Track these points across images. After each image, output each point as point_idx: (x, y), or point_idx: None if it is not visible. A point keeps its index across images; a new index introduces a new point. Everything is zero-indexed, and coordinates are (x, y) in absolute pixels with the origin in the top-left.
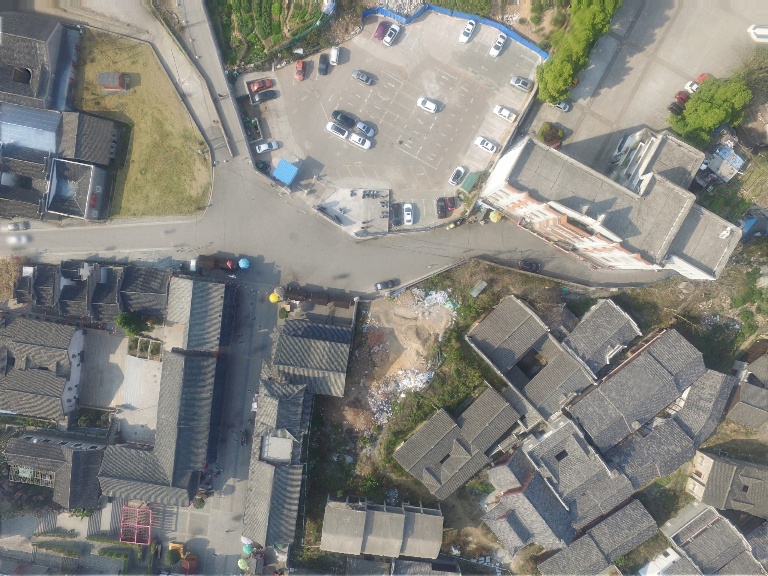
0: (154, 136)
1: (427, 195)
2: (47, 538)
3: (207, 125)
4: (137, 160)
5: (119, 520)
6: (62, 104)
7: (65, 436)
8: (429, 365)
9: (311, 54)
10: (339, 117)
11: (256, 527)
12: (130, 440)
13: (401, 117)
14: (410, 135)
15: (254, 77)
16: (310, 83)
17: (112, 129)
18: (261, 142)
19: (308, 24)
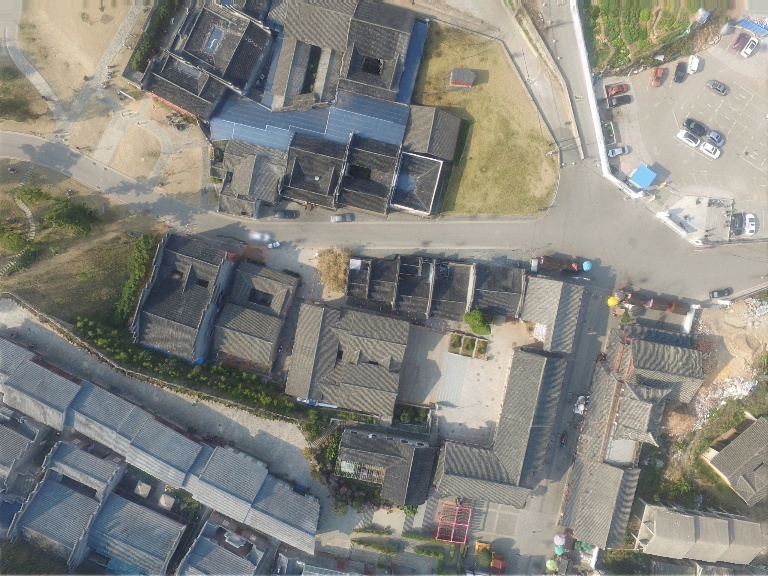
0: (498, 134)
1: (767, 206)
2: (365, 534)
3: (556, 126)
4: (476, 157)
5: (429, 518)
6: (408, 97)
7: (385, 432)
8: (754, 374)
9: (668, 61)
10: (693, 125)
11: (592, 529)
12: (448, 438)
13: (749, 128)
14: (756, 147)
15: (612, 81)
16: (664, 90)
17: (459, 125)
18: (613, 146)
19: (677, 32)
